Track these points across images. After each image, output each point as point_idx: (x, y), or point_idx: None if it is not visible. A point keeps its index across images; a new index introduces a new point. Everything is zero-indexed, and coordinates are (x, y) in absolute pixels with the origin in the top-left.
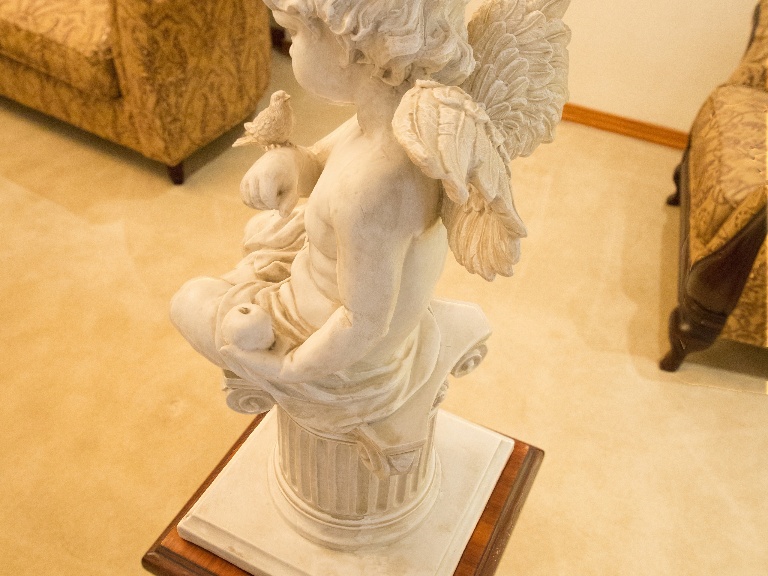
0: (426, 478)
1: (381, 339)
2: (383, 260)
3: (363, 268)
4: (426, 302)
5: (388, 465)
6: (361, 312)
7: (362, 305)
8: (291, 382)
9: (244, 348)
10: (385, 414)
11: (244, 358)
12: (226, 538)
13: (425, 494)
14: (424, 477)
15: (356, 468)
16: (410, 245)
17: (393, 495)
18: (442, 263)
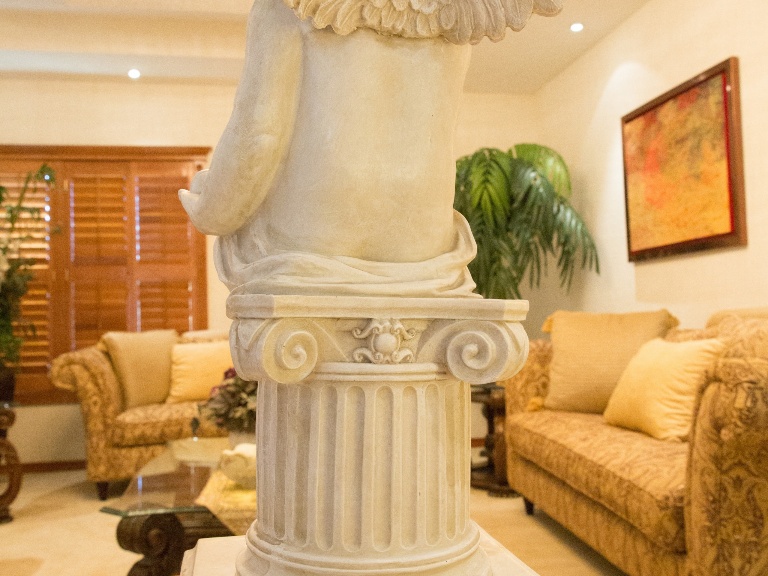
0: (395, 553)
1: (256, 147)
2: (257, 41)
3: (246, 56)
4: (337, 145)
5: (236, 334)
6: (236, 103)
7: (238, 95)
8: (197, 213)
9: (192, 190)
10: (266, 280)
11: (184, 194)
12: (192, 561)
13: (375, 567)
14: (389, 545)
15: (275, 428)
16: (303, 48)
17: (314, 512)
18: (404, 146)
